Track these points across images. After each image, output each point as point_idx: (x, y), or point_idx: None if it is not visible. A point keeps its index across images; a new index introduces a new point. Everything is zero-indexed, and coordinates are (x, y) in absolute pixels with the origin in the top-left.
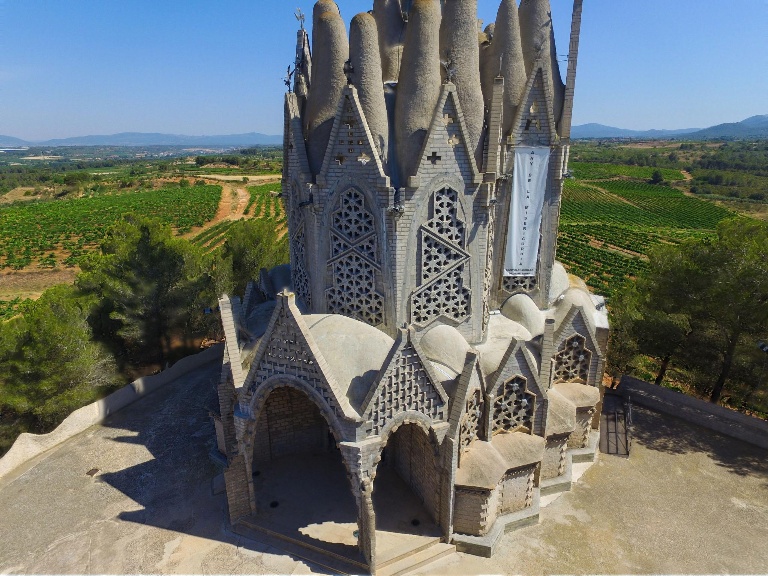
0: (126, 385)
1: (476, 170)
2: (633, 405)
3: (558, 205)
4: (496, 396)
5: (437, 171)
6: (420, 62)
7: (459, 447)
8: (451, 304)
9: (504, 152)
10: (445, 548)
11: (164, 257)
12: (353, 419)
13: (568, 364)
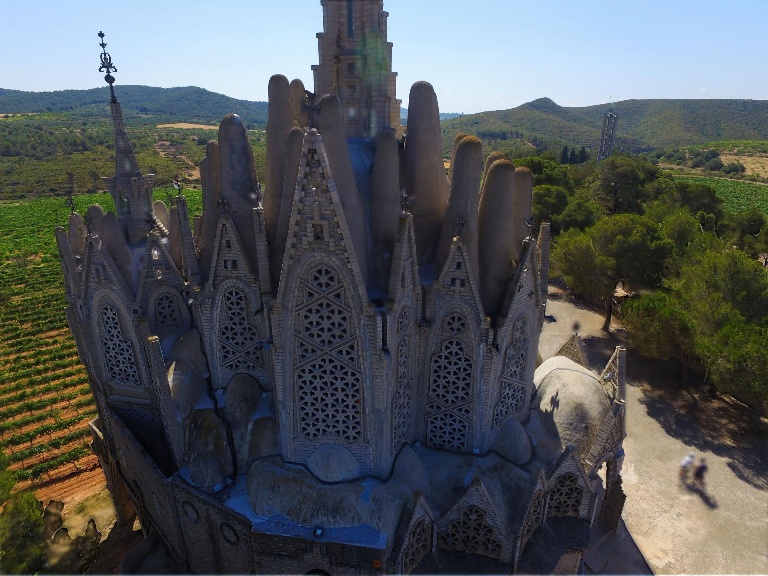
0: None
1: None
2: None
3: None
4: None
5: None
6: None
7: None
8: None
9: None
10: None
11: None
12: None
13: None
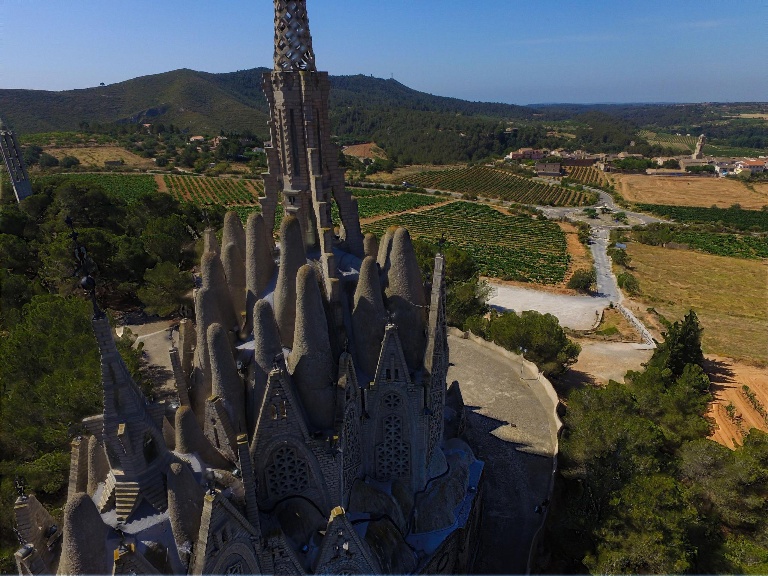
0: None
1: None
2: None
3: None
4: None
5: None
6: None
7: None
8: None
9: None
10: None
11: None
12: None
13: None
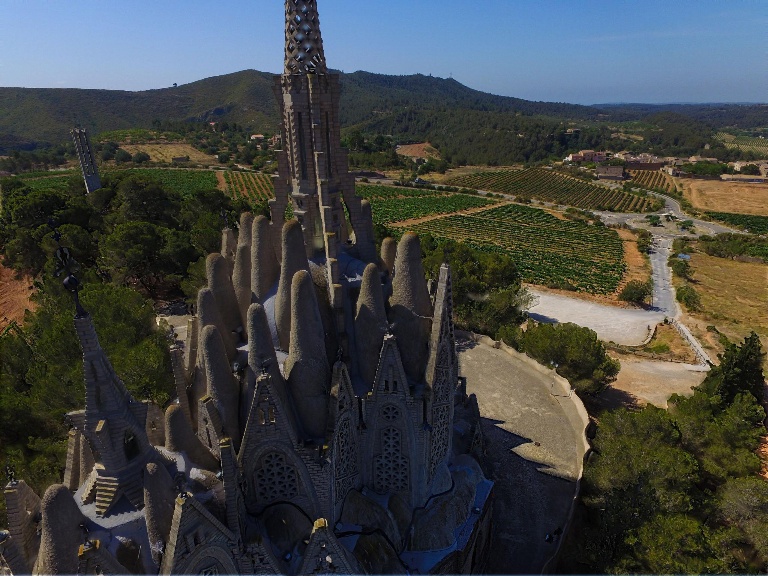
0: (583, 501)
1: None
2: None
3: None
4: None
5: None
6: None
7: None
8: None
9: None
10: None
11: None
12: None
13: None
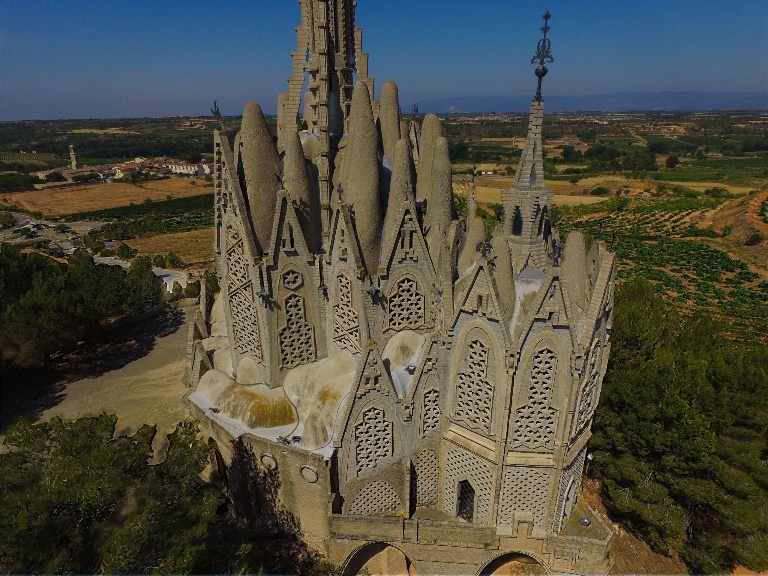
0: None
1: None
2: None
3: (225, 297)
4: None
5: None
6: None
7: None
8: None
9: None
10: None
11: None
12: None
13: None
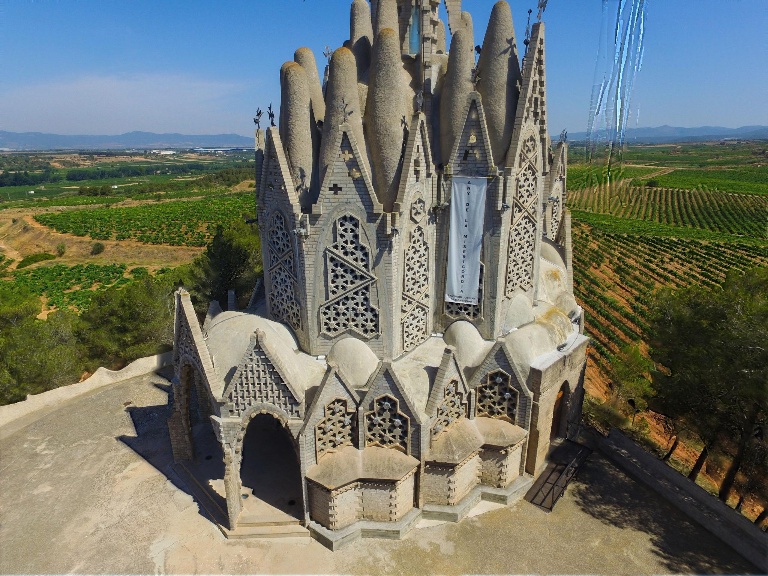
0: None
1: (375, 201)
2: (610, 464)
3: (504, 236)
4: (368, 410)
5: (339, 201)
6: (333, 104)
7: (315, 445)
8: (360, 320)
9: (441, 181)
10: (300, 530)
11: (233, 251)
12: (215, 399)
13: (493, 399)
